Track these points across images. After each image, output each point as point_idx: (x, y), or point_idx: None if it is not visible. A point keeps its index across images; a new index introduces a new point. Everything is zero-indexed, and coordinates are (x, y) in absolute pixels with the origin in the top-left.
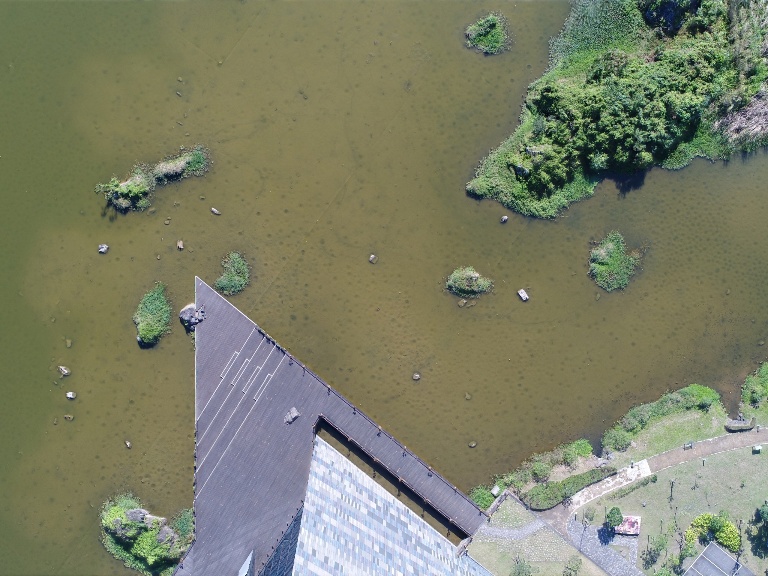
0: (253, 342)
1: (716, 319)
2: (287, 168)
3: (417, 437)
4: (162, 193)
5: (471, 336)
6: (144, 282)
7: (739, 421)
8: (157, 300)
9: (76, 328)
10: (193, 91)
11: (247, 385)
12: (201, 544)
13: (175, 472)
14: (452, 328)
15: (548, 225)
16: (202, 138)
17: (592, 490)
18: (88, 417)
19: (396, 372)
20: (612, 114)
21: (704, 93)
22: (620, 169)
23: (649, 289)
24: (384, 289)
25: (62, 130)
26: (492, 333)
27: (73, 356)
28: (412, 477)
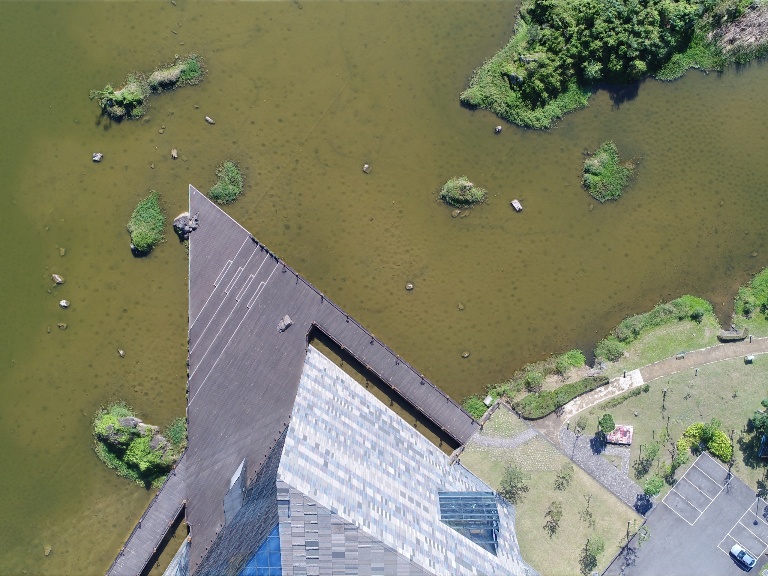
0: (247, 250)
1: (709, 230)
2: (281, 77)
3: (410, 347)
4: (156, 102)
5: (464, 246)
6: (138, 191)
7: (732, 332)
8: (151, 208)
9: (70, 237)
10: (188, 0)
11: (240, 293)
12: (194, 451)
13: (168, 381)
14: (445, 238)
15: (542, 136)
16: (197, 47)
17: (584, 399)
18: (81, 325)
19: (389, 282)
20: (606, 21)
21: (698, 2)
22: (614, 79)
23: (642, 200)
24: (378, 199)
25: (57, 39)
26: (485, 243)
27: (67, 264)
28: (405, 385)
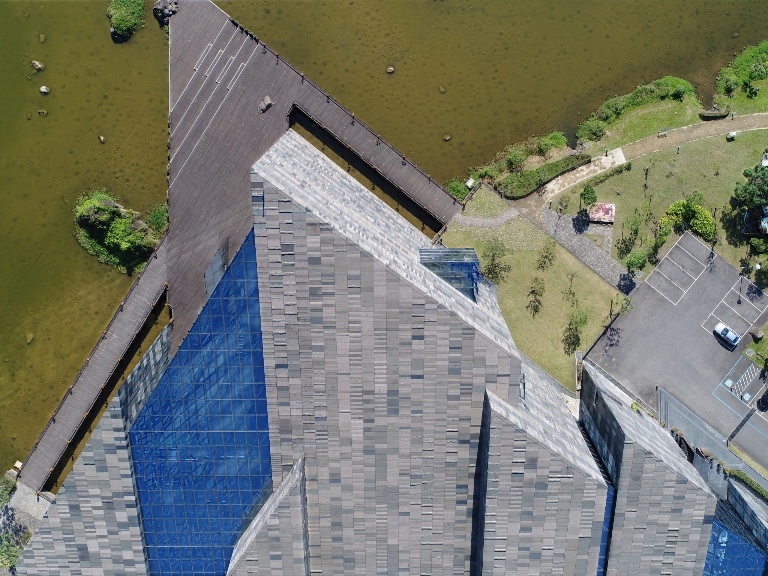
0: (227, 33)
1: (690, 11)
2: None
3: (391, 131)
4: None
5: (445, 29)
6: None
7: (713, 110)
8: None
9: (49, 23)
10: None
11: (221, 75)
12: (175, 234)
13: (149, 167)
14: (426, 21)
15: None
16: None
17: (566, 178)
18: (62, 112)
19: (370, 65)
20: None
21: None
22: None
23: None
24: None
25: None
26: (466, 26)
27: (47, 51)
28: (386, 166)
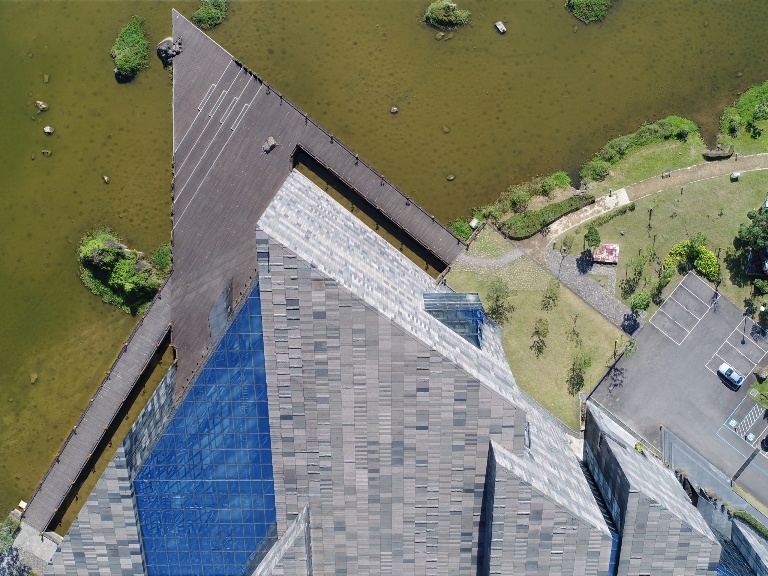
0: (230, 74)
1: (694, 51)
2: None
3: (395, 171)
4: None
5: (449, 69)
6: (121, 16)
7: (717, 150)
8: (134, 33)
9: (53, 63)
10: None
11: (224, 116)
12: (179, 274)
13: (153, 207)
14: (430, 61)
15: None
16: None
17: (570, 219)
18: (66, 152)
19: (374, 105)
20: None
21: None
22: None
23: (627, 21)
24: (361, 22)
25: None
26: (470, 66)
27: (51, 91)
28: (390, 206)
